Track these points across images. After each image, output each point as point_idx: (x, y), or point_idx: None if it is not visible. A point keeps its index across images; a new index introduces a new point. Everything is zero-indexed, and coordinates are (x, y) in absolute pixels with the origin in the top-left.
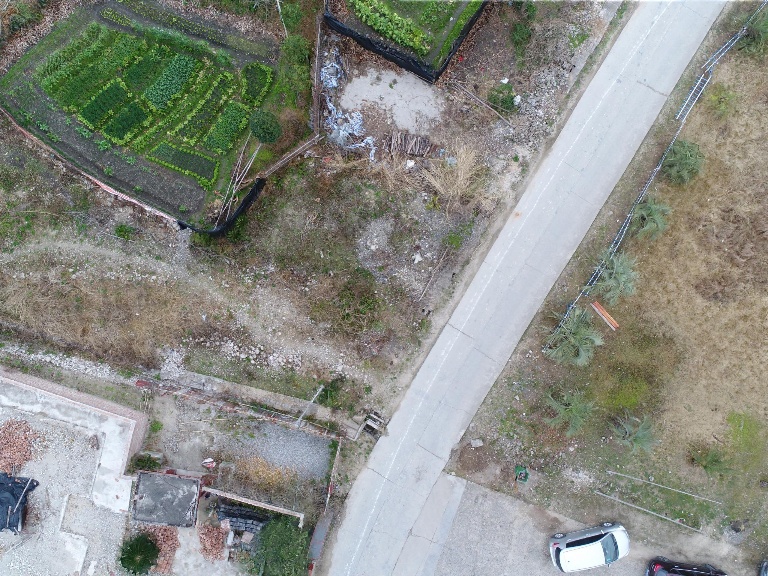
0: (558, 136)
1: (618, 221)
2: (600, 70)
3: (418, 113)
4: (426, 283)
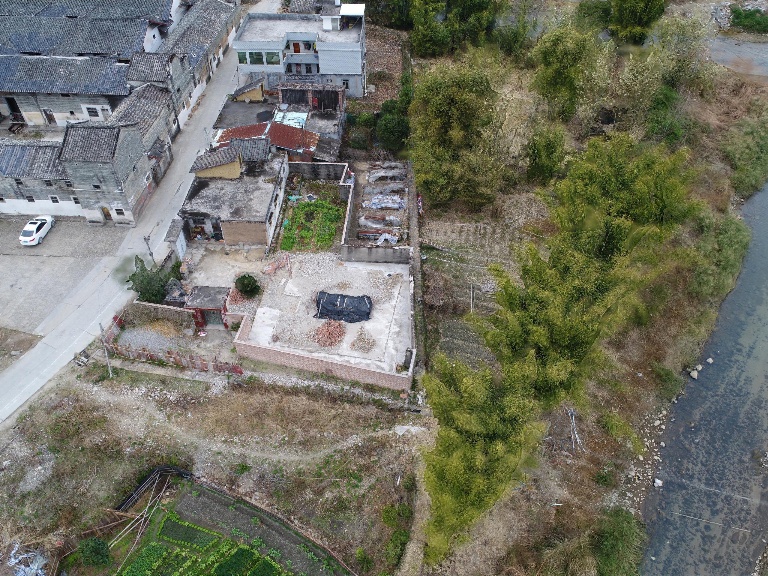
0: None
1: None
2: None
3: None
4: (8, 447)
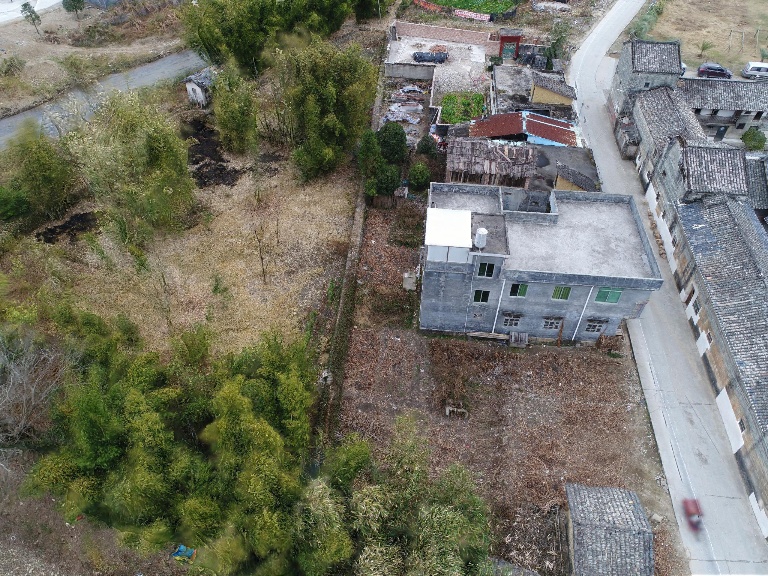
0: None
1: (641, 21)
2: (619, 0)
3: None
4: None
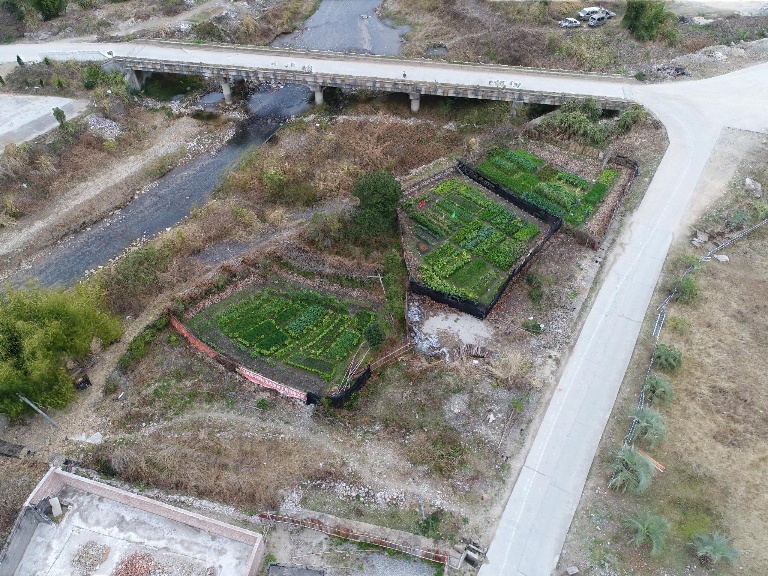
0: (575, 344)
1: (636, 395)
2: (592, 310)
3: (476, 335)
4: (501, 436)
